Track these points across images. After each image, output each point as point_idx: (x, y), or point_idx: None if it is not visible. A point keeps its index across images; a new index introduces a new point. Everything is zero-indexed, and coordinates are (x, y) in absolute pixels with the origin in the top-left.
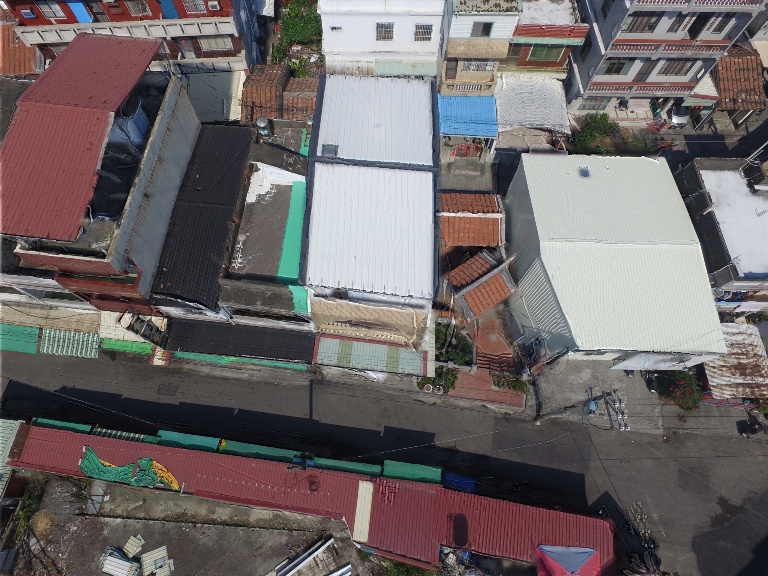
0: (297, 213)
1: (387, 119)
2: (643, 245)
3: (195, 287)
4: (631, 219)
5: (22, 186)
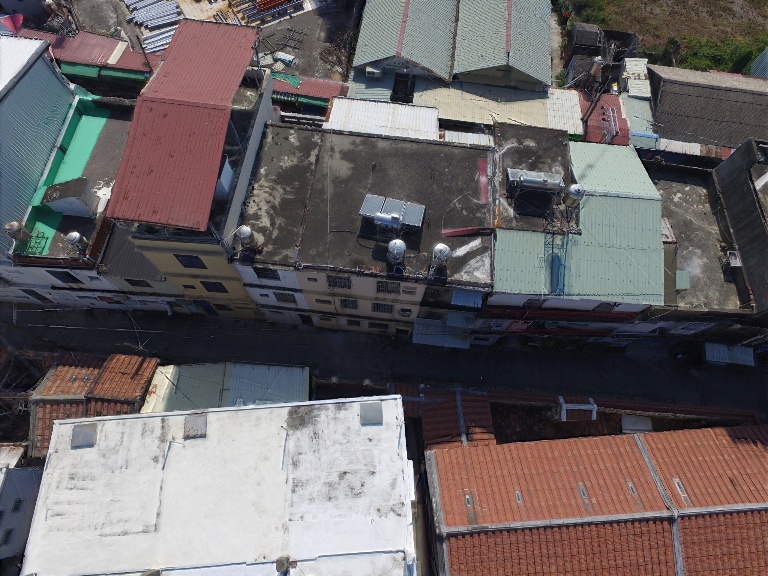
0: (76, 168)
1: None
2: None
3: None
4: None
5: (224, 51)
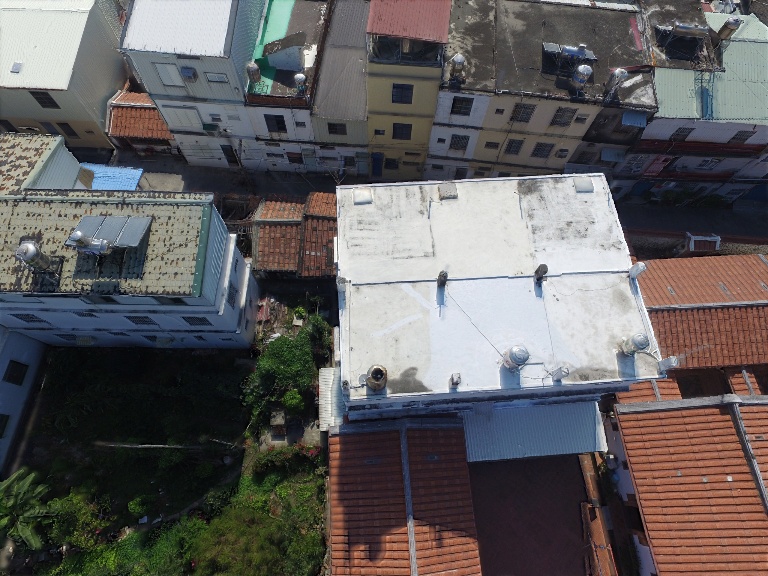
0: (278, 36)
1: (175, 3)
2: (8, 7)
3: (356, 4)
4: (5, 15)
5: None
